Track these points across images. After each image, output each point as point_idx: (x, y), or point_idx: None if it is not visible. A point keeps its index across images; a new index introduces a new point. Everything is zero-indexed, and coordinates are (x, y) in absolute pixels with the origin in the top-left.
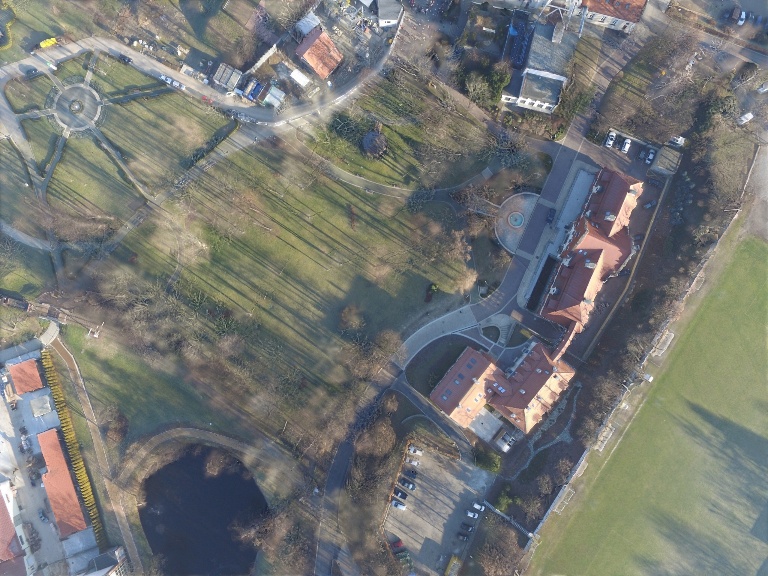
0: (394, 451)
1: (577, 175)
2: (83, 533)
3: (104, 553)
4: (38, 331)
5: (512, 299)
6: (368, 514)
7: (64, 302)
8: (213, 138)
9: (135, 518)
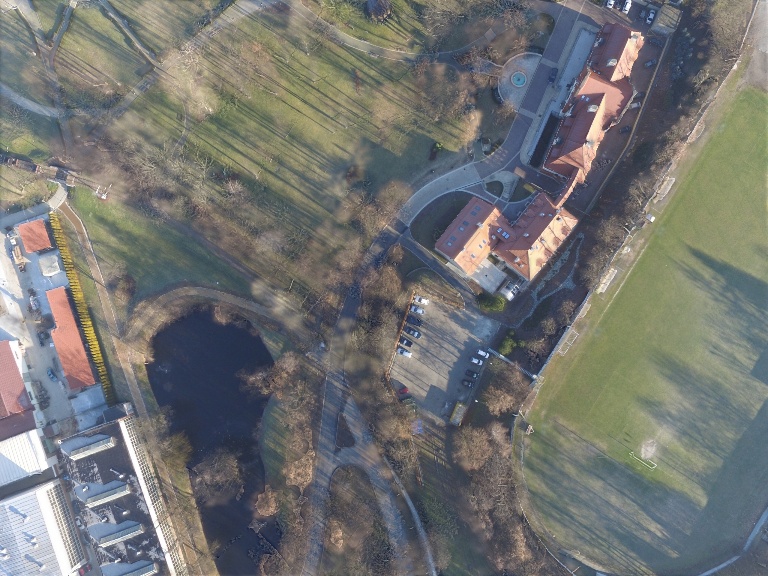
0: (400, 298)
1: (579, 35)
2: (91, 391)
3: (113, 406)
4: (46, 195)
5: (515, 156)
6: (374, 363)
7: (72, 163)
8: (219, 5)
9: (143, 376)
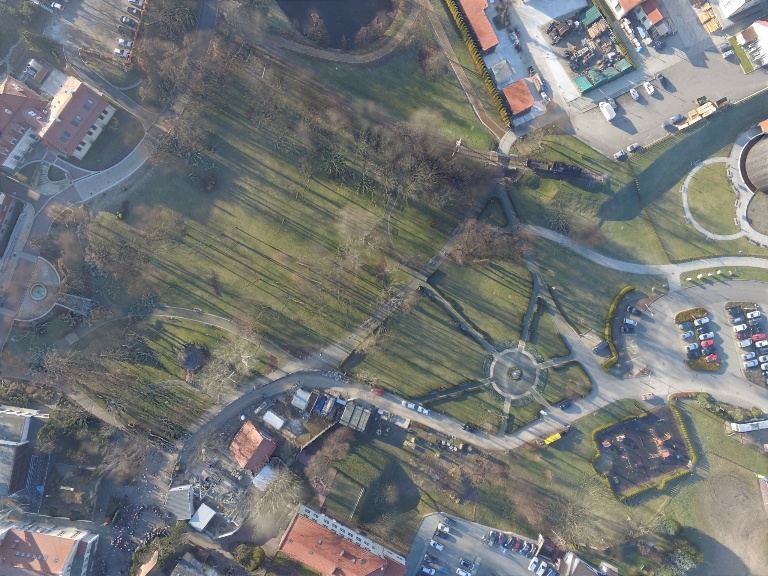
0: None
1: None
2: None
3: None
4: (519, 144)
5: (39, 211)
6: None
7: None
8: (366, 352)
9: None
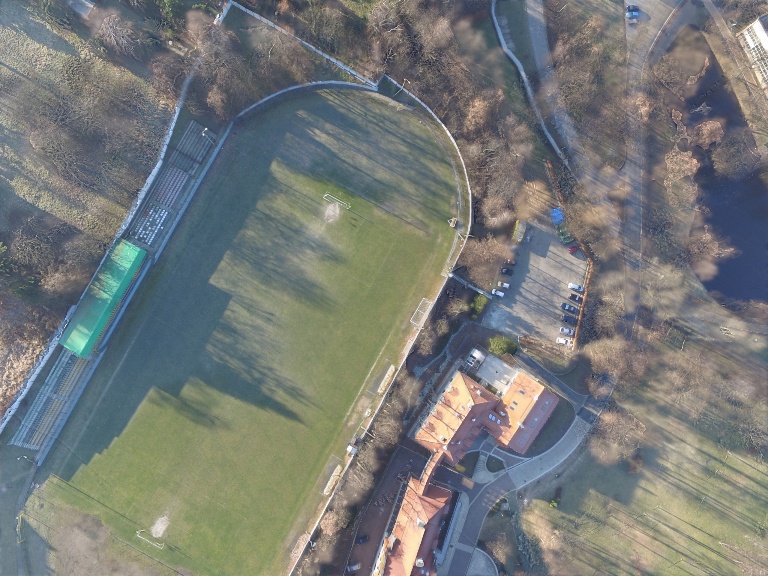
0: (589, 342)
1: None
2: None
3: None
4: None
5: (474, 500)
6: (603, 274)
7: None
8: None
9: None
